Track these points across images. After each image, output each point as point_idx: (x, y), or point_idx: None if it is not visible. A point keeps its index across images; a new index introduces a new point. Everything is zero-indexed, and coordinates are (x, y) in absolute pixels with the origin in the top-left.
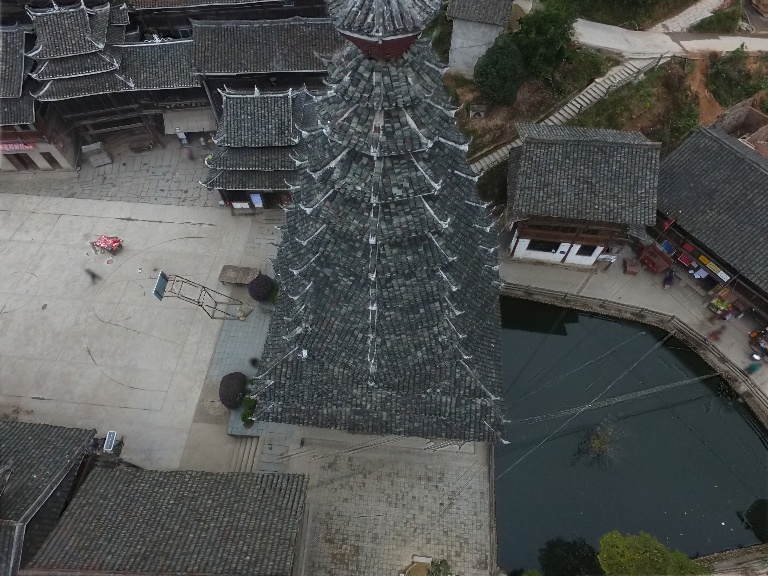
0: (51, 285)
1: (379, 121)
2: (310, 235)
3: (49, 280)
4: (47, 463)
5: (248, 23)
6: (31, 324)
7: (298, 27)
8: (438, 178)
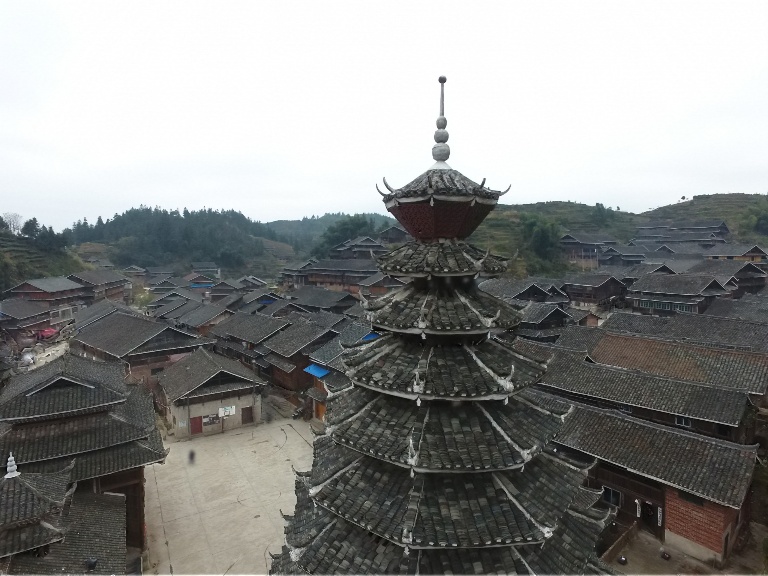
0: (278, 507)
1: (397, 296)
2: (323, 432)
3: (281, 503)
4: (80, 570)
5: (565, 401)
6: (238, 520)
7: (613, 419)
8: (429, 383)
